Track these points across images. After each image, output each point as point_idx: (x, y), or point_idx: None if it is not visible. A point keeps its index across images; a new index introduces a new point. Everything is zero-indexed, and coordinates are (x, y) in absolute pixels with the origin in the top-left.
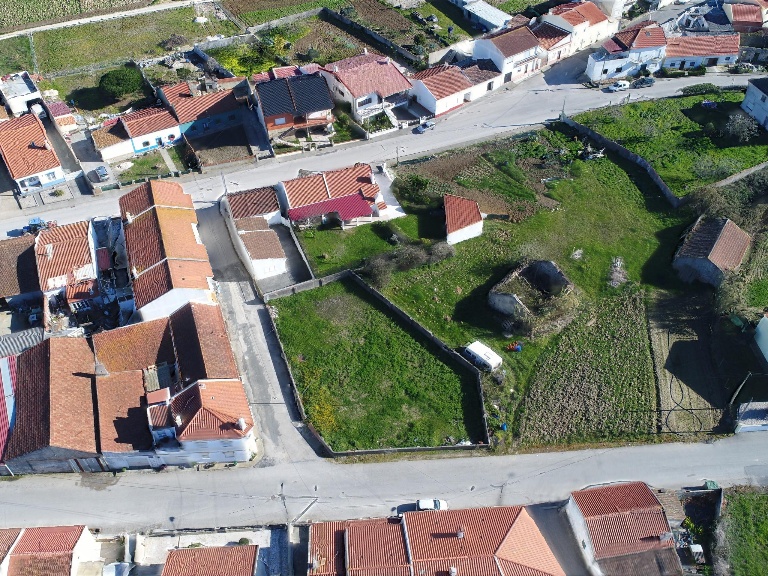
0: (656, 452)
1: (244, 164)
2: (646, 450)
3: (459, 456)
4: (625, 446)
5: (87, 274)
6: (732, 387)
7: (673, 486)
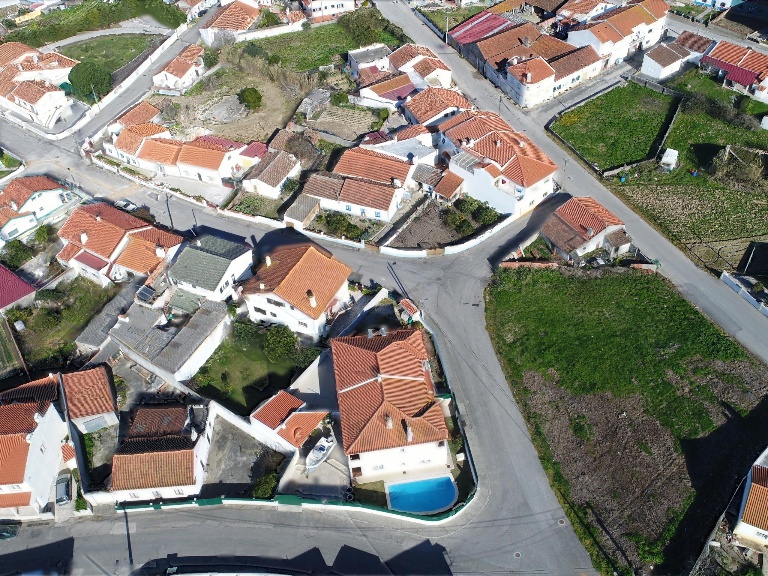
0: (664, 243)
1: (736, 36)
2: (662, 239)
3: (587, 170)
4: (657, 230)
5: (579, 17)
6: (766, 273)
7: (642, 252)
